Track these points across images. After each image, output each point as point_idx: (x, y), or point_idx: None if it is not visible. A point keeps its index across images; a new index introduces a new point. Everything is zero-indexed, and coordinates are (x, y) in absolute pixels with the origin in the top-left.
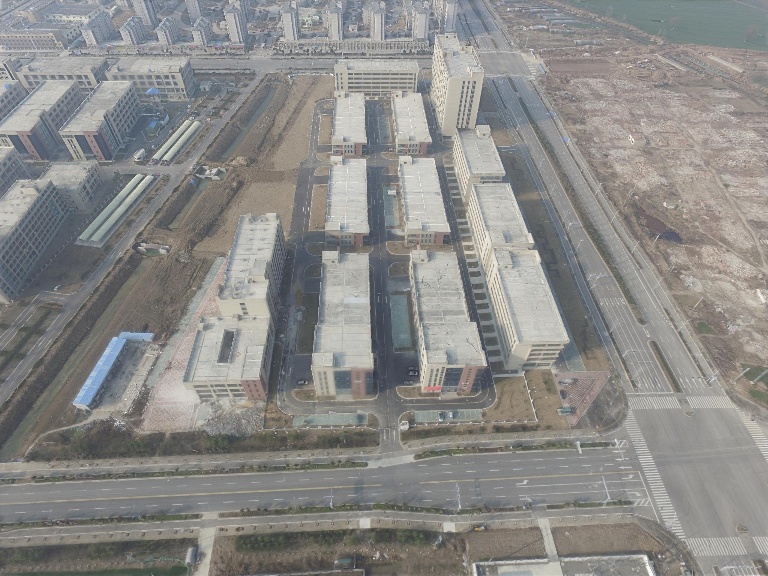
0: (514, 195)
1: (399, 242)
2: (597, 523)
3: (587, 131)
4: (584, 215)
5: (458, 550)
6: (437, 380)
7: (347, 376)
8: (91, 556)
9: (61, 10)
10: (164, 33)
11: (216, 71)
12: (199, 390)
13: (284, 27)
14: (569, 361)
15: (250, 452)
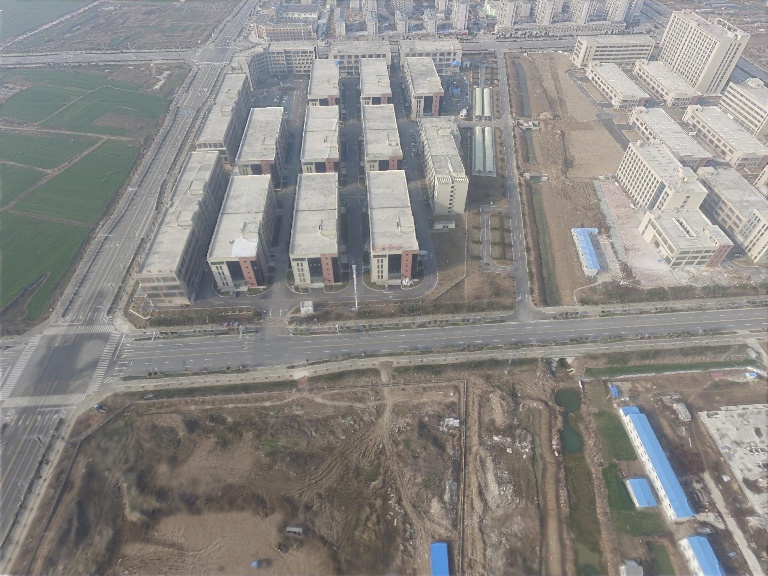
0: None
1: (727, 166)
2: None
3: None
4: None
5: None
6: None
7: None
8: (685, 354)
9: (290, 9)
10: (405, 23)
11: None
12: (678, 257)
13: (502, 15)
14: None
15: (737, 296)
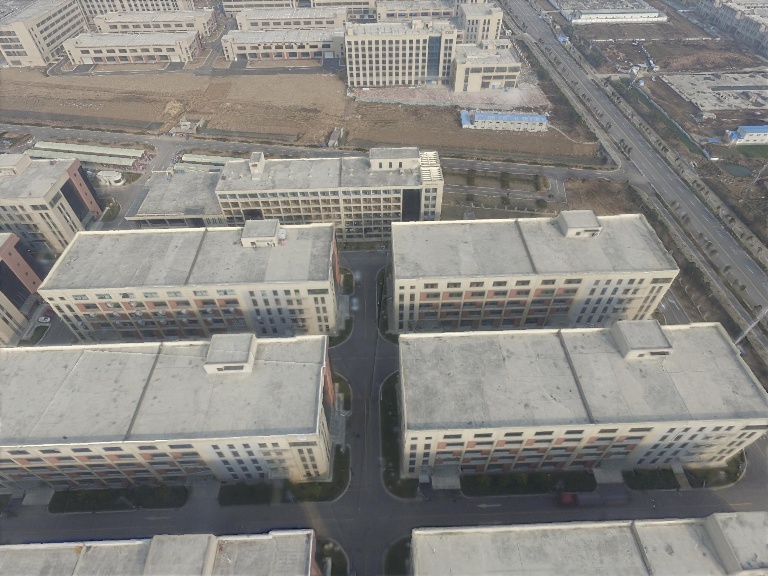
0: None
1: None
2: (539, 4)
3: None
4: None
5: None
6: None
7: None
8: None
9: None
10: None
11: None
12: None
13: None
14: None
15: None
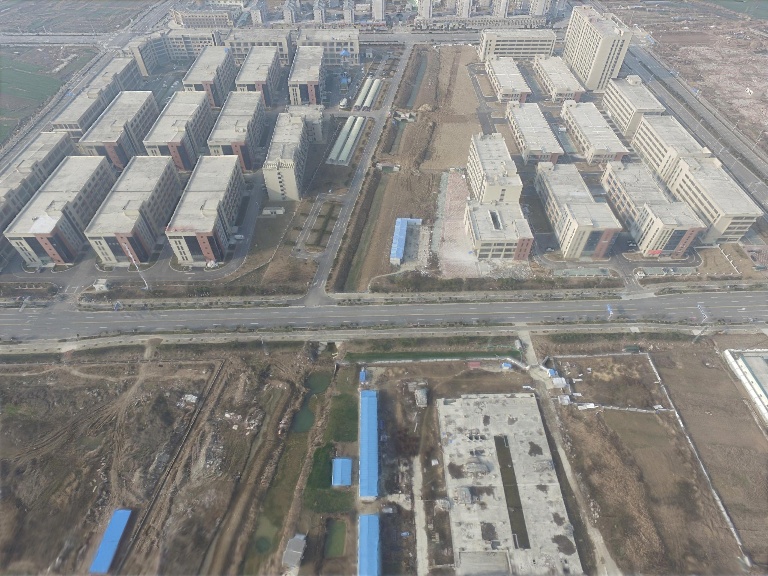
0: (678, 124)
1: (583, 163)
2: None
3: (708, 86)
4: (728, 145)
5: (709, 345)
6: (661, 243)
7: (598, 237)
8: (450, 343)
9: None
10: (320, 12)
11: (370, 43)
12: (482, 249)
13: (421, 7)
14: (751, 239)
15: (531, 290)
